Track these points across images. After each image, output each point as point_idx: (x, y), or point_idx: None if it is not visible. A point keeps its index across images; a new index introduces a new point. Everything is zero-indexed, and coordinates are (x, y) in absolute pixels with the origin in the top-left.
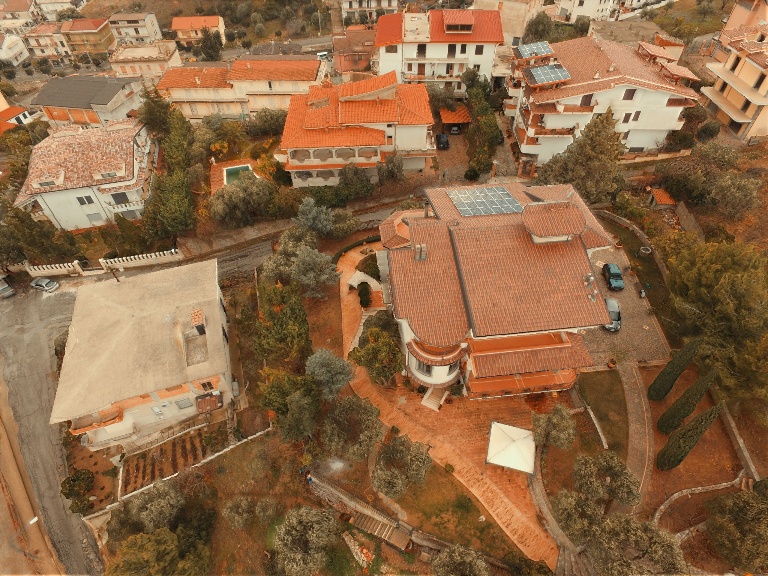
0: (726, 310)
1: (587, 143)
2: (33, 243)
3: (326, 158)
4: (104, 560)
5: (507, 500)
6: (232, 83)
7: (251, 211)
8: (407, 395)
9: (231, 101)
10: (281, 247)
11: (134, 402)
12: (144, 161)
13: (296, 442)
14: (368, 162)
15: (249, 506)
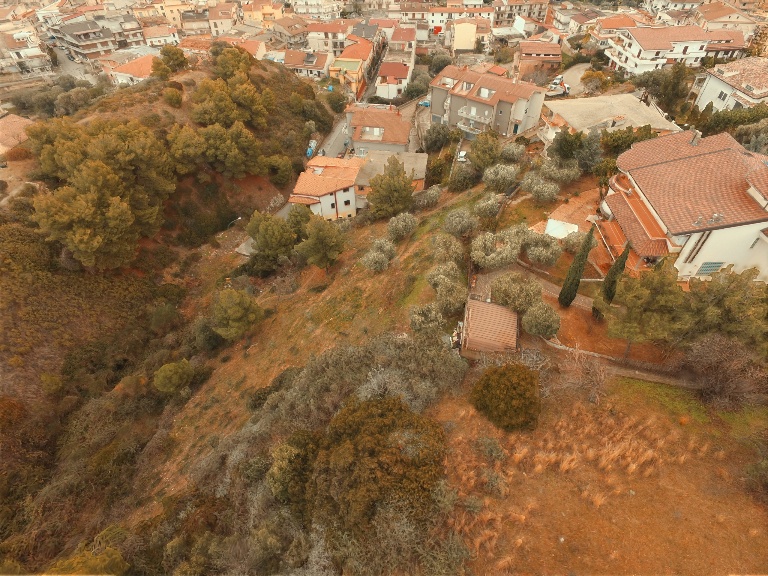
0: None
1: None
2: None
3: None
4: None
5: None
6: None
7: None
8: (594, 209)
9: None
10: None
11: None
12: None
13: None
14: None
15: None
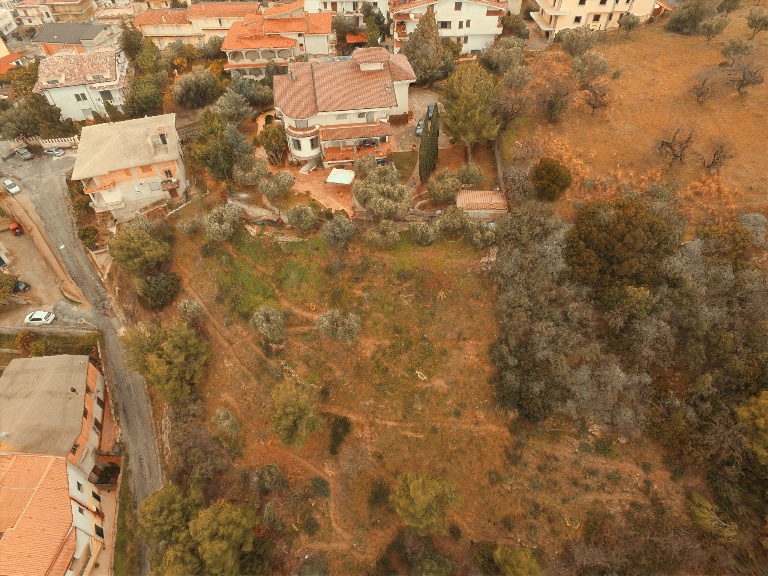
0: (456, 93)
1: (419, 31)
2: (45, 119)
3: (255, 59)
4: (106, 287)
5: (338, 203)
6: (191, 20)
7: (202, 95)
8: (291, 169)
9: (190, 35)
10: (218, 102)
11: (122, 178)
12: (124, 72)
13: (222, 195)
14: (285, 62)
15: (193, 223)
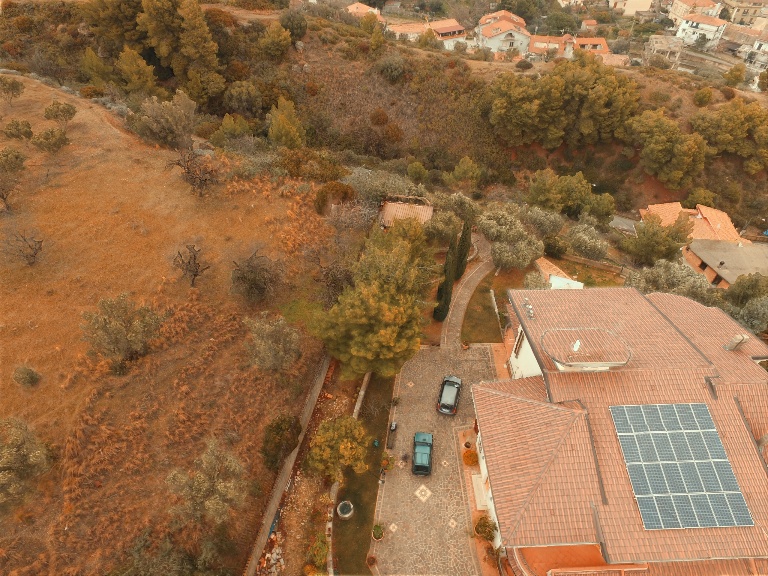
0: None
1: None
2: None
3: None
4: None
5: None
6: None
7: None
8: None
9: None
10: None
11: None
12: None
13: None
14: None
15: None
